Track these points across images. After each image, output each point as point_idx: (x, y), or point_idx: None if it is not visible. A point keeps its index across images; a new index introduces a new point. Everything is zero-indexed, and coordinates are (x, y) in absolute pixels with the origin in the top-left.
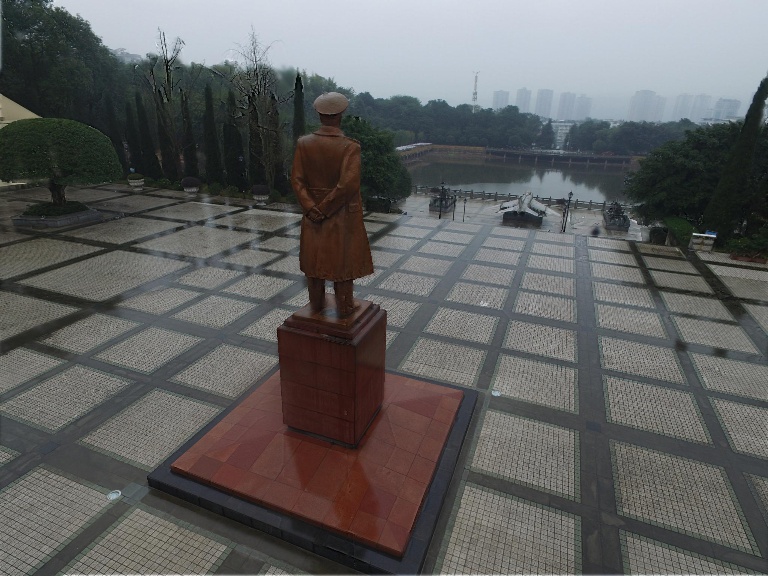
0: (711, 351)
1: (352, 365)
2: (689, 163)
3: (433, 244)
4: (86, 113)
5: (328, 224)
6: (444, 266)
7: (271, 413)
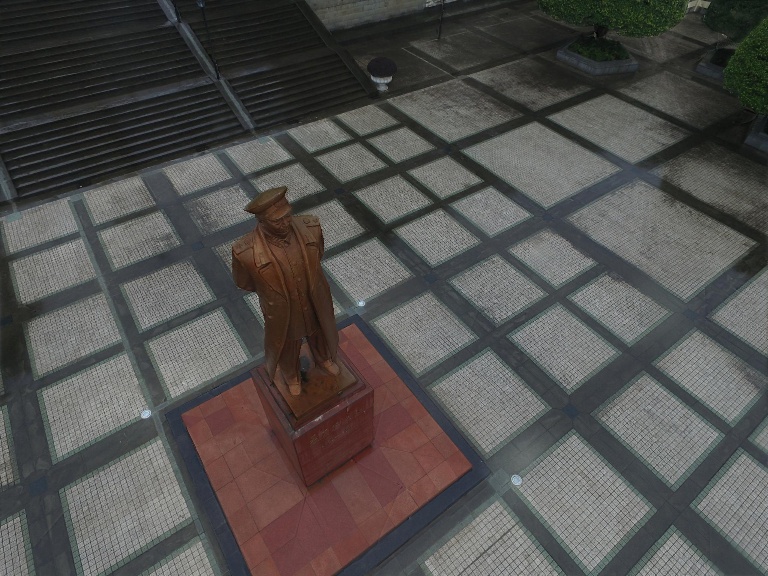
0: None
1: None
2: None
3: None
4: None
5: None
6: None
7: None
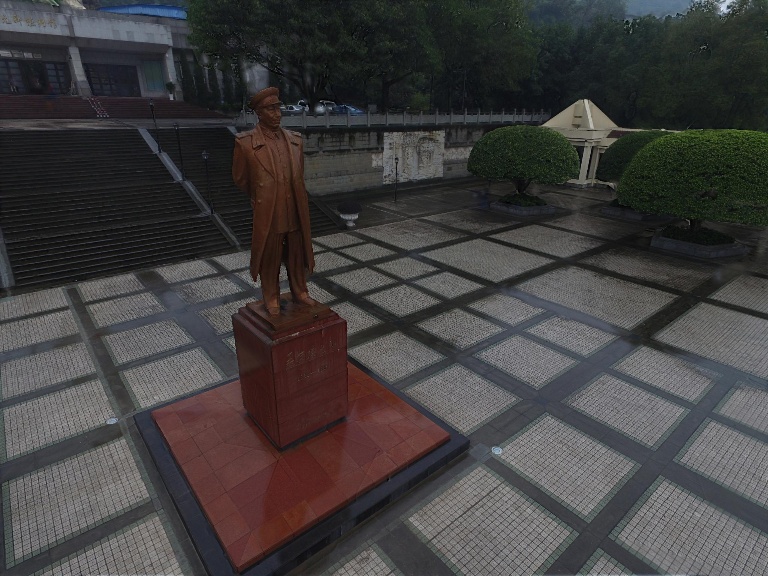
0: None
1: None
2: None
3: None
4: None
5: None
6: None
7: None
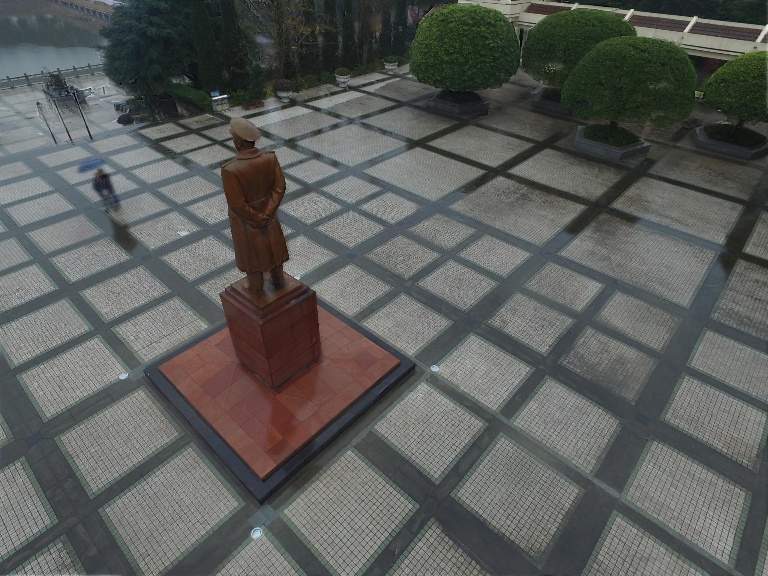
0: (326, 182)
1: (315, 305)
2: (160, 32)
3: (18, 209)
4: None
5: (272, 223)
6: (83, 224)
7: (245, 399)
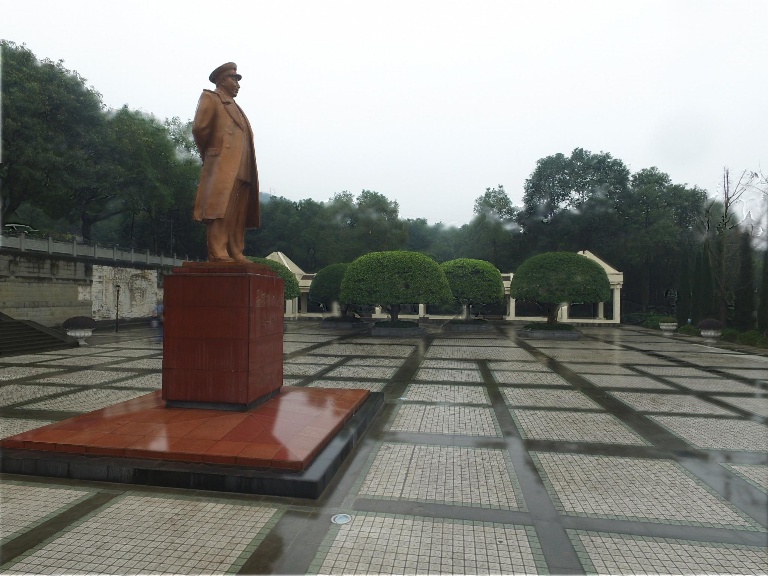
0: None
1: None
2: None
3: None
4: (662, 267)
5: None
6: None
7: None
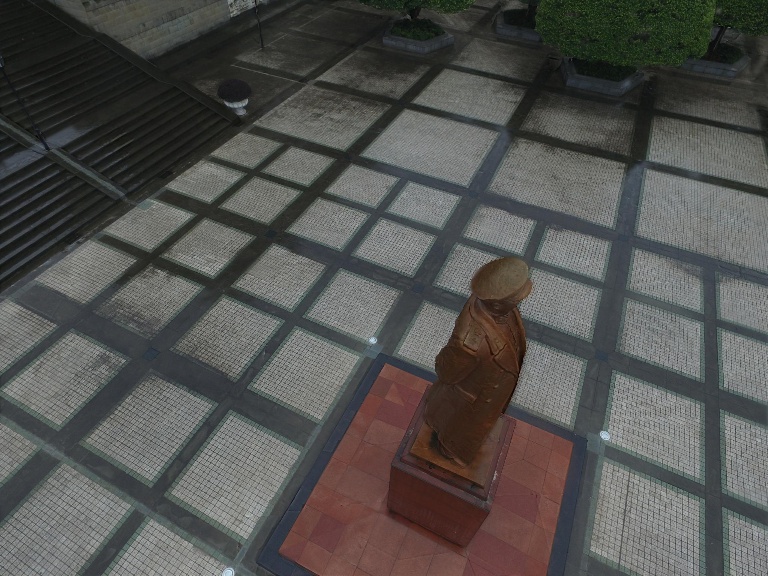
0: None
1: None
2: None
3: None
4: None
5: None
6: None
7: None
